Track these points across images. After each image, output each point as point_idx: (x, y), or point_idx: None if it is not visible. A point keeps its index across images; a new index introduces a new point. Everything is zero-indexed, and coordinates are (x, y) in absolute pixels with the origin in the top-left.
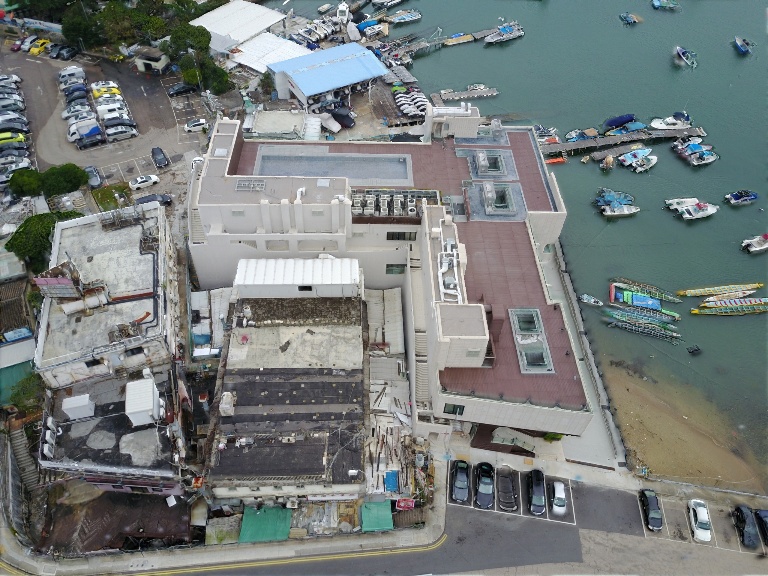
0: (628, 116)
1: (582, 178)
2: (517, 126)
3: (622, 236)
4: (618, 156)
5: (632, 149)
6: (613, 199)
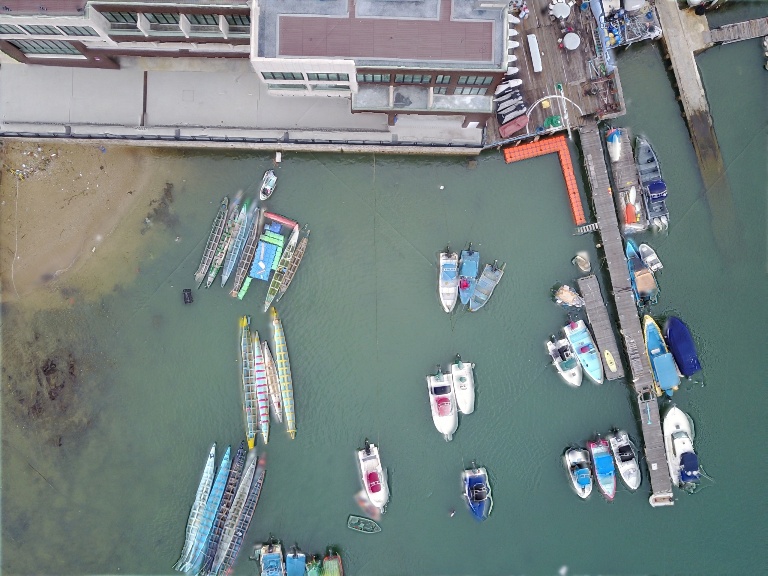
0: (694, 367)
1: (535, 247)
2: (507, 41)
3: (401, 273)
4: (588, 322)
5: (605, 351)
6: (466, 272)
